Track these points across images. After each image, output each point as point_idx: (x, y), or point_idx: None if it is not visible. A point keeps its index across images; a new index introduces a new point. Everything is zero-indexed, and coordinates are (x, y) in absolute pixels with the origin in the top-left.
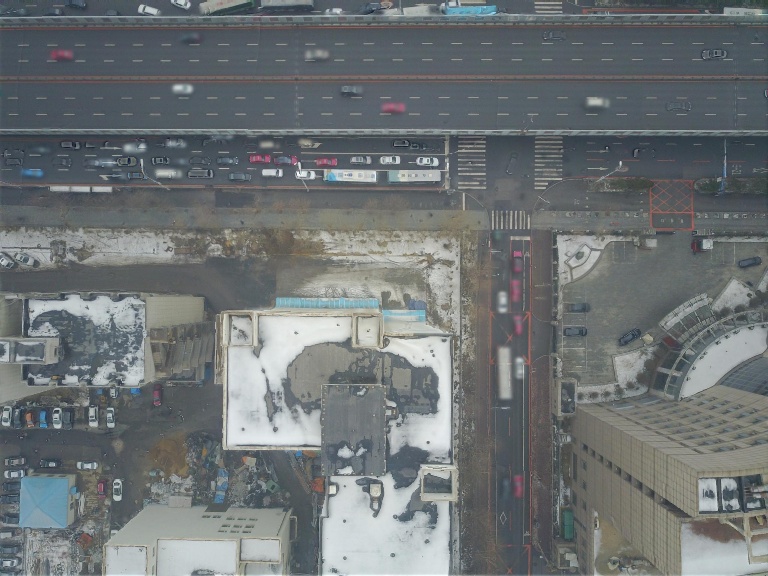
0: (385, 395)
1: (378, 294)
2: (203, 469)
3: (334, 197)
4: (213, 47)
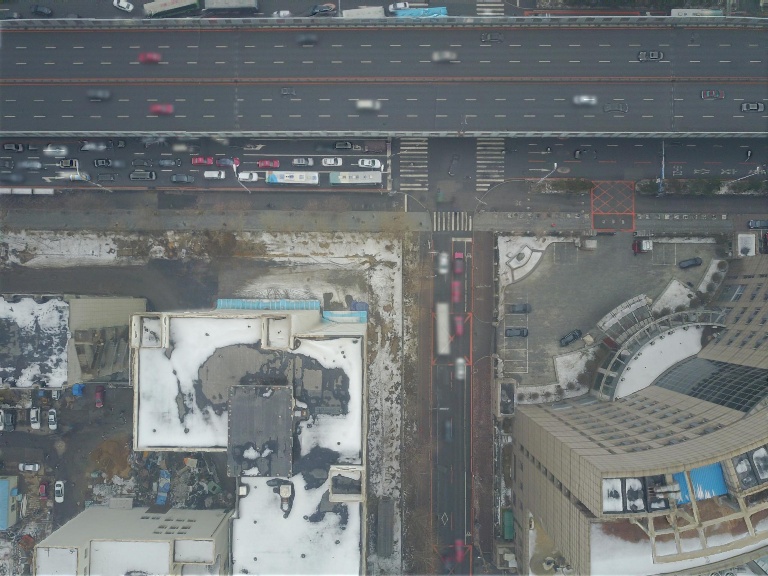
0: (291, 396)
1: (320, 295)
2: (144, 470)
3: (276, 199)
4: (153, 49)
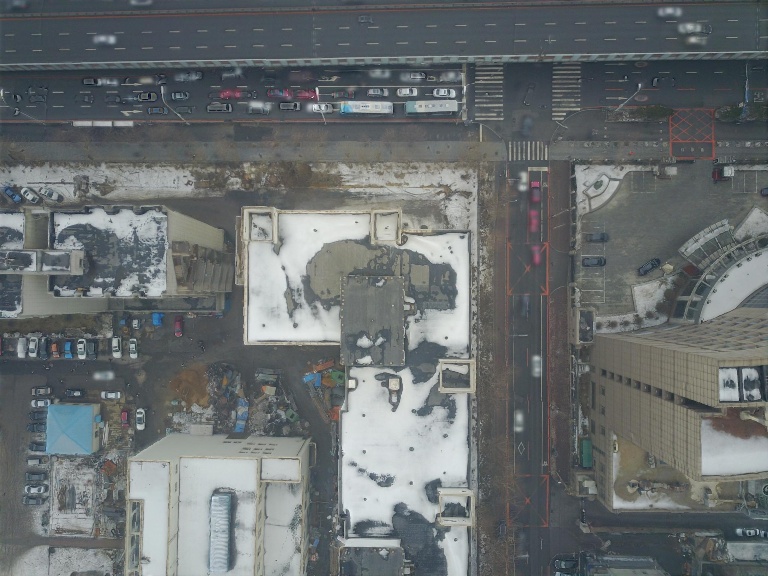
0: (403, 286)
1: None
2: (224, 398)
3: (351, 130)
4: None
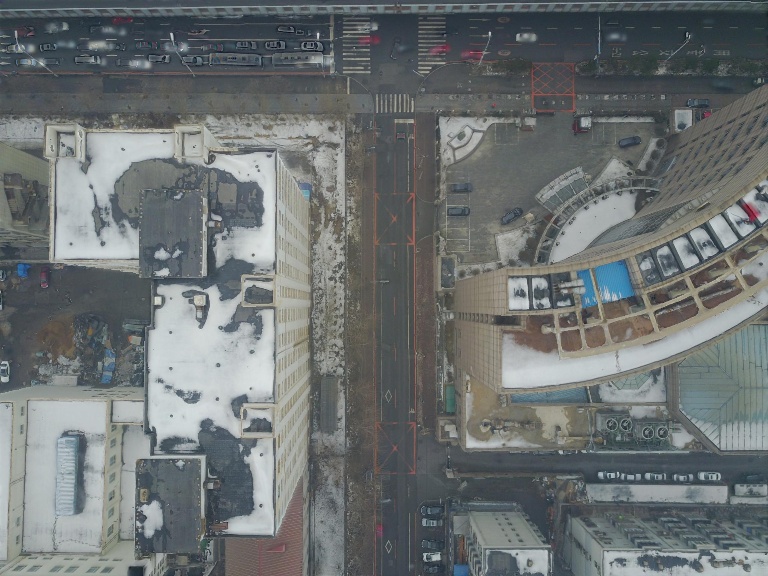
0: (201, 199)
1: None
2: (89, 349)
3: (220, 82)
4: None
